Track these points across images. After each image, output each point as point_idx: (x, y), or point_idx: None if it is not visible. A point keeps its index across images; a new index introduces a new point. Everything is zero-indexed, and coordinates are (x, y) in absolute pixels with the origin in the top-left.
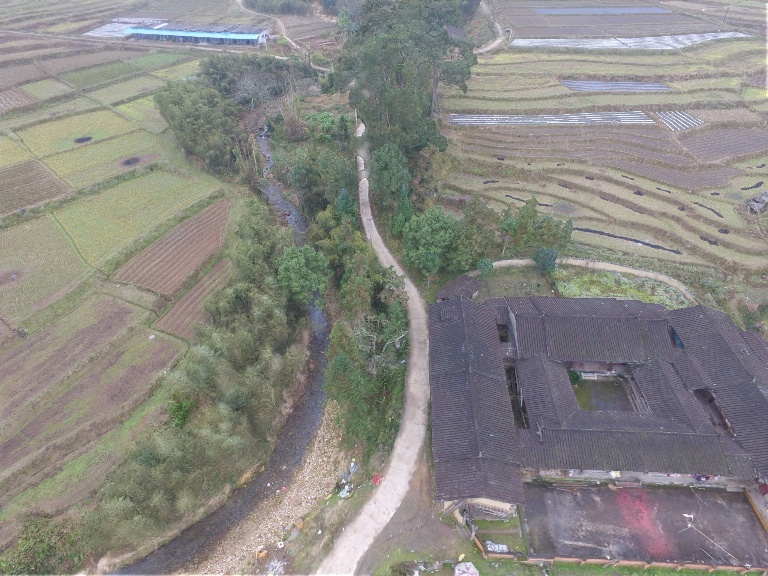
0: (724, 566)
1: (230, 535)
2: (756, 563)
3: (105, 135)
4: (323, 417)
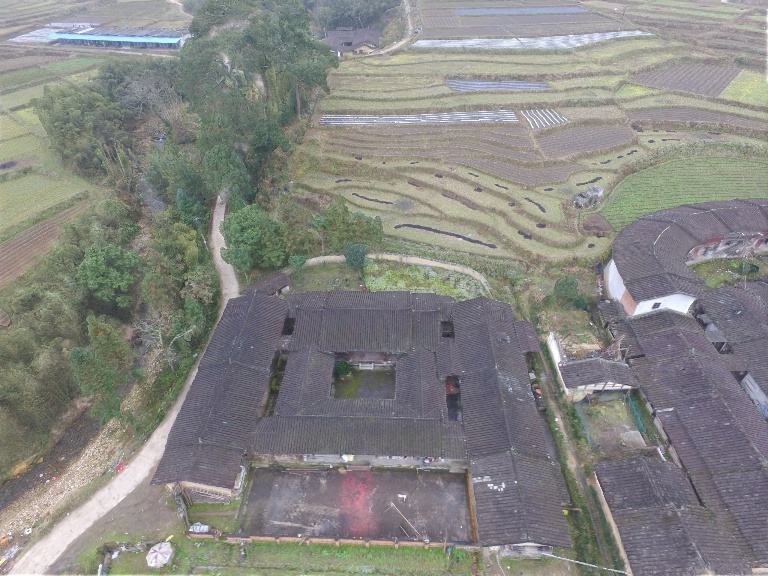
0: (406, 541)
1: None
2: (446, 539)
3: None
4: None
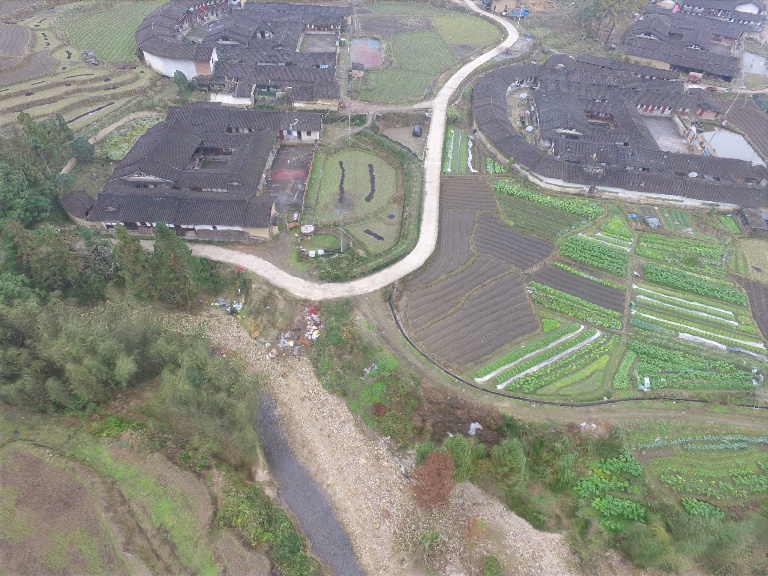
0: None
1: None
2: None
3: None
4: None
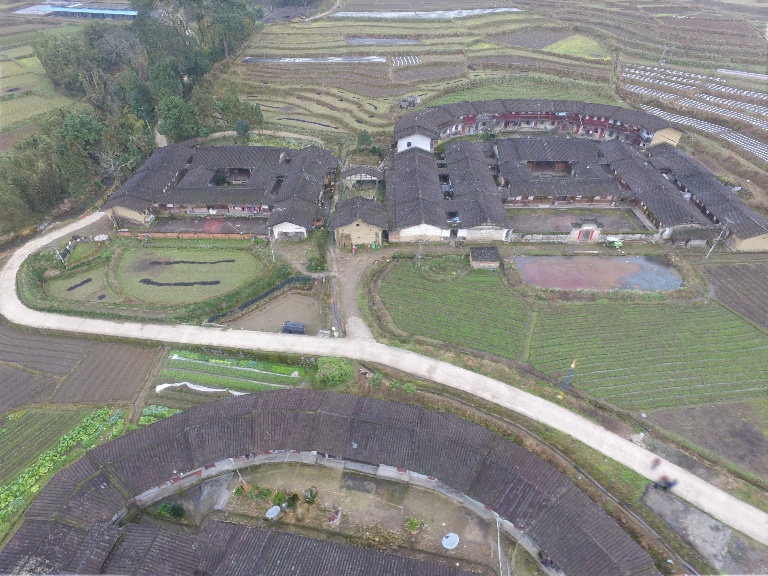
0: (231, 234)
1: (7, 251)
2: None
3: (1, 75)
4: (86, 211)
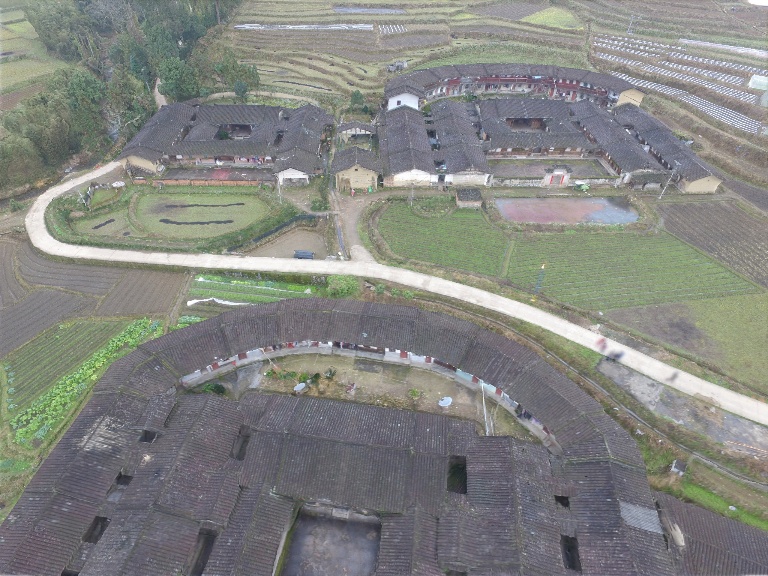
0: (239, 181)
1: (24, 201)
2: None
3: None
4: (94, 166)
